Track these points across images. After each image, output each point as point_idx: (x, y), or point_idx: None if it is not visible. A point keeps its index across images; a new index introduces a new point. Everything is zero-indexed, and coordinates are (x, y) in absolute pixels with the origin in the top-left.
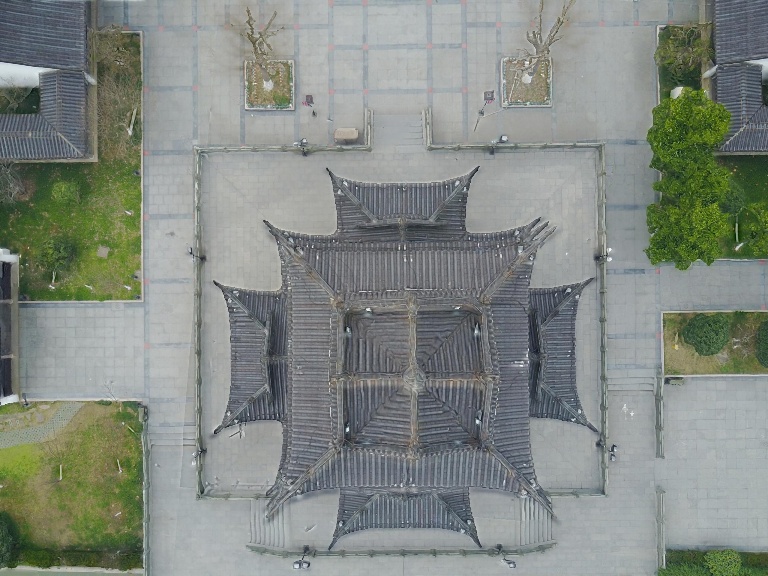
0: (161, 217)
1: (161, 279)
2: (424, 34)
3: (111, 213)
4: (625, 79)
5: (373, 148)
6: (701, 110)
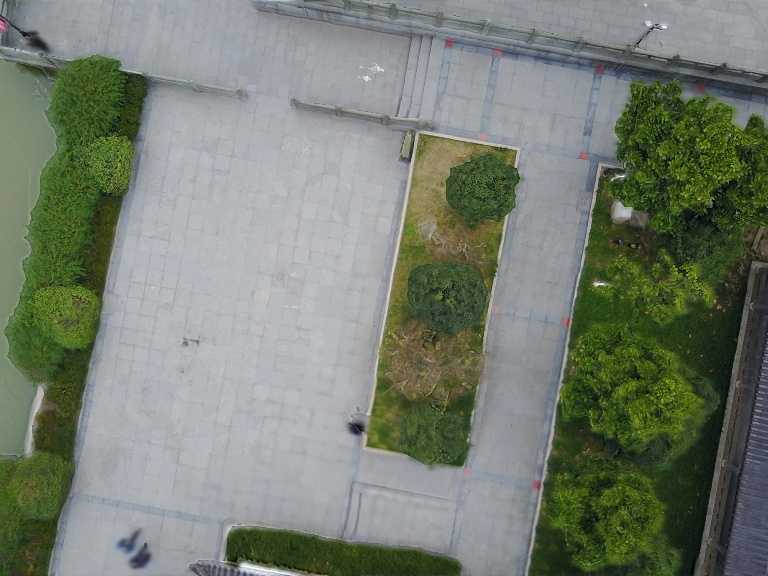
0: None
1: None
2: None
3: None
4: None
5: None
6: None
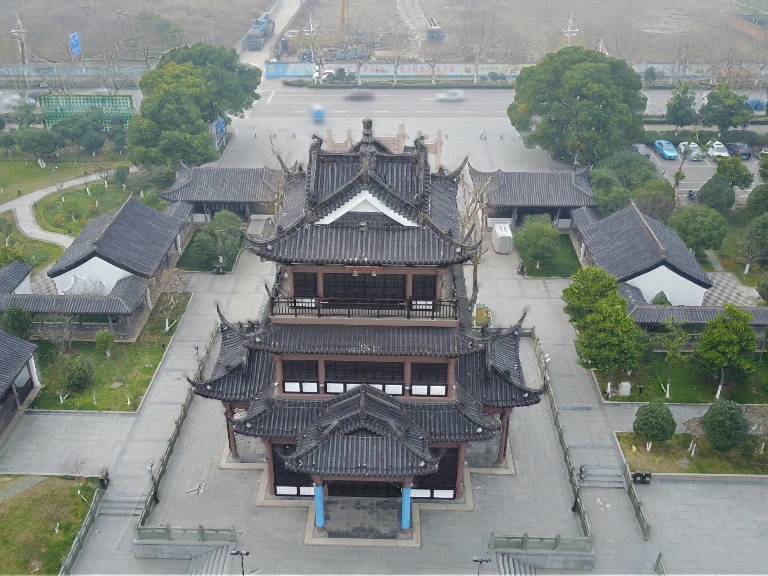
0: (173, 370)
1: (159, 402)
2: None
3: (133, 366)
4: (547, 319)
5: None
6: (592, 271)
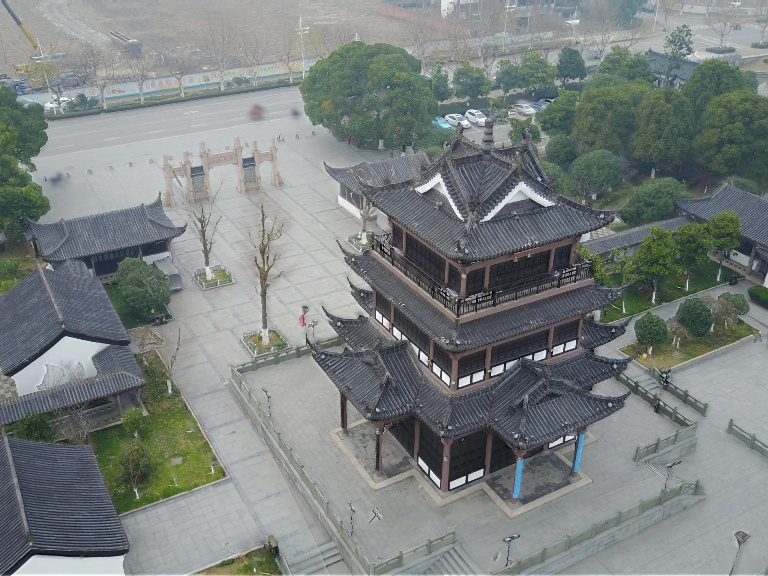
0: (219, 427)
1: (238, 460)
2: (353, 299)
3: (174, 437)
4: None
5: None
6: None
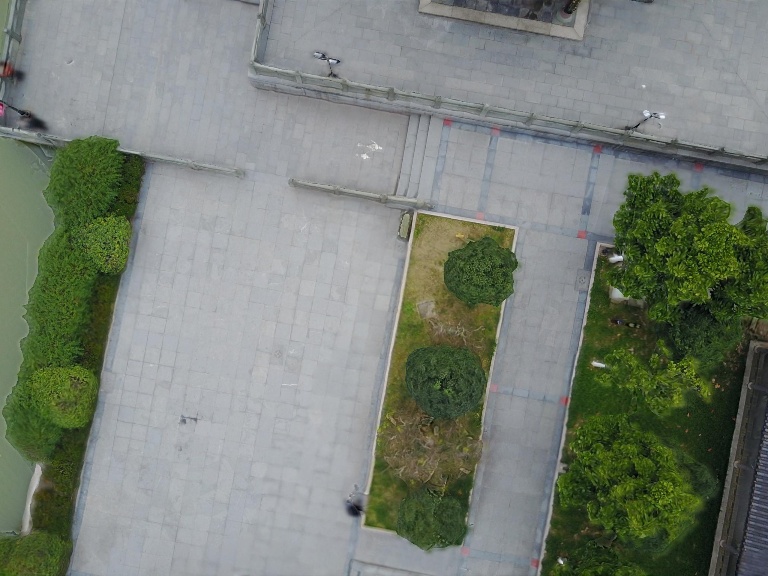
0: None
1: None
2: None
3: None
4: None
5: None
6: None
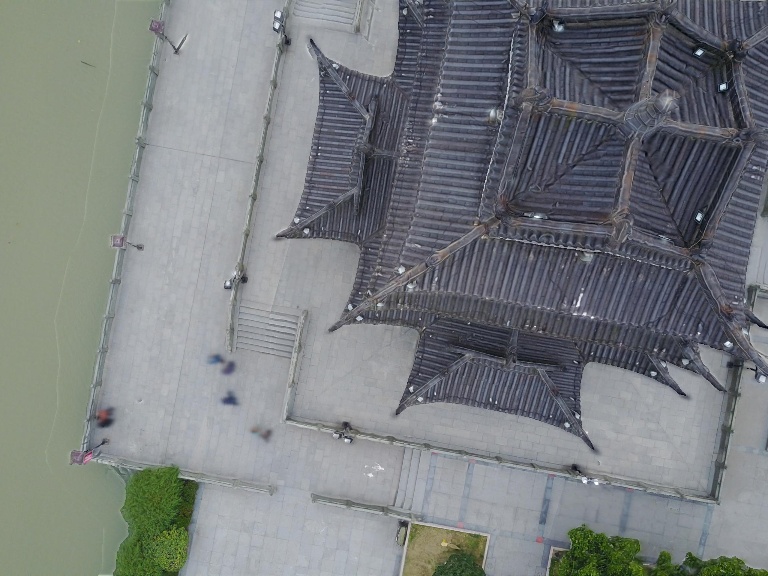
0: None
1: None
2: None
3: None
4: None
5: (765, 219)
6: None
